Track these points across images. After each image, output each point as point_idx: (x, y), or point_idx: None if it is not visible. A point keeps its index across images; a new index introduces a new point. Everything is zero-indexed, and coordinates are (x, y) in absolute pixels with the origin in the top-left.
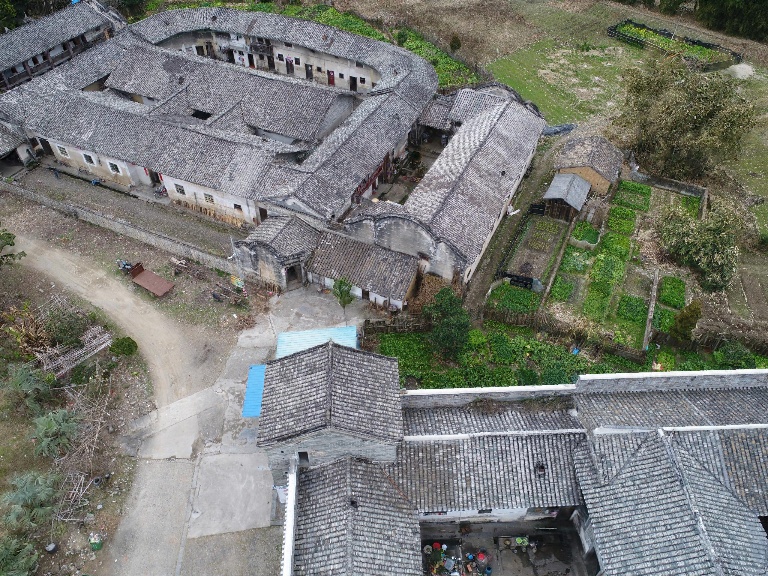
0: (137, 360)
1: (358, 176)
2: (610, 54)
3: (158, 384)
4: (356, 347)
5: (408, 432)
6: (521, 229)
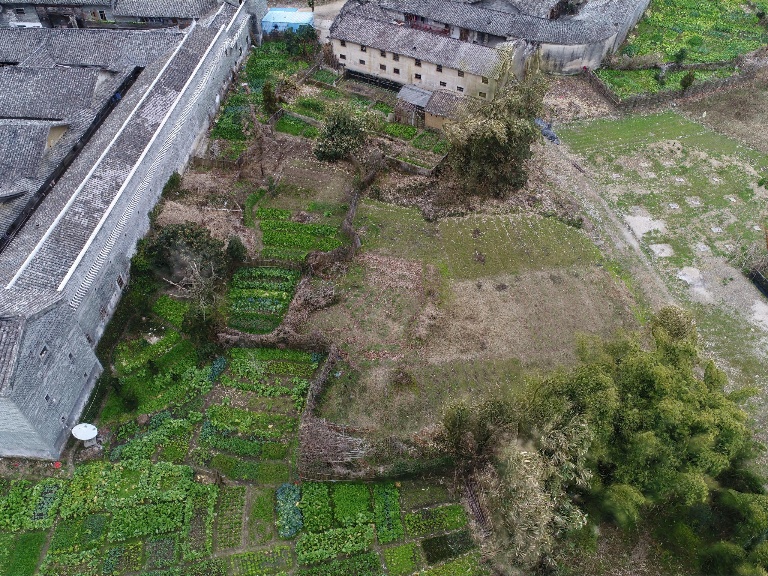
0: (323, 3)
1: (418, 12)
2: (765, 205)
3: (309, 8)
4: (297, 24)
5: (228, 7)
6: (396, 92)
